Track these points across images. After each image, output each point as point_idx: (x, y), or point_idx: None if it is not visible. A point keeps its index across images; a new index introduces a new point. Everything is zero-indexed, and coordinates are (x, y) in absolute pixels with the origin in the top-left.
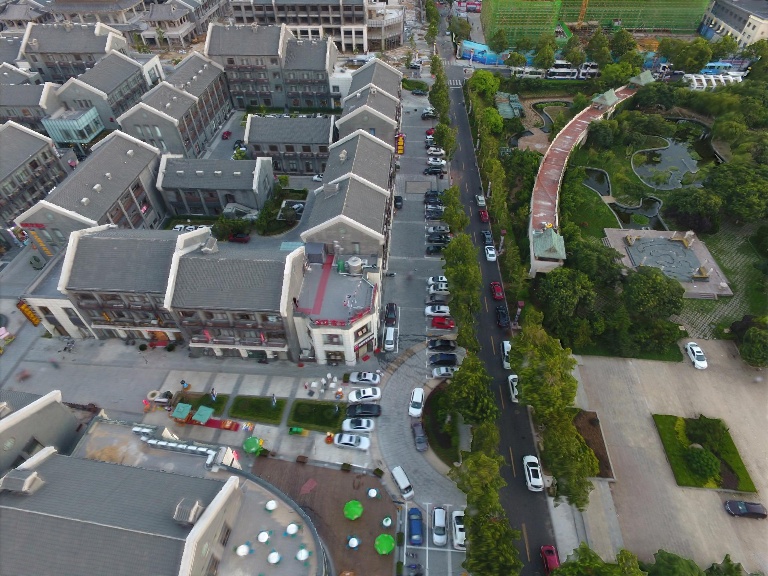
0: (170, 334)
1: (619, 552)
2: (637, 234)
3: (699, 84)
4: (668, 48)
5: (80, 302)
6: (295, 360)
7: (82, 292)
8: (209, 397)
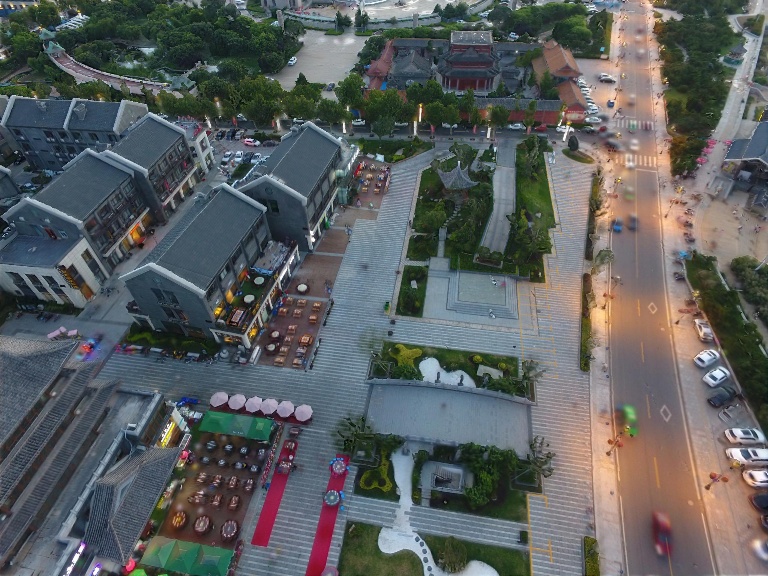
0: (141, 225)
1: None
2: None
3: (73, 27)
4: (20, 20)
5: (90, 234)
6: (199, 179)
7: (89, 220)
8: None
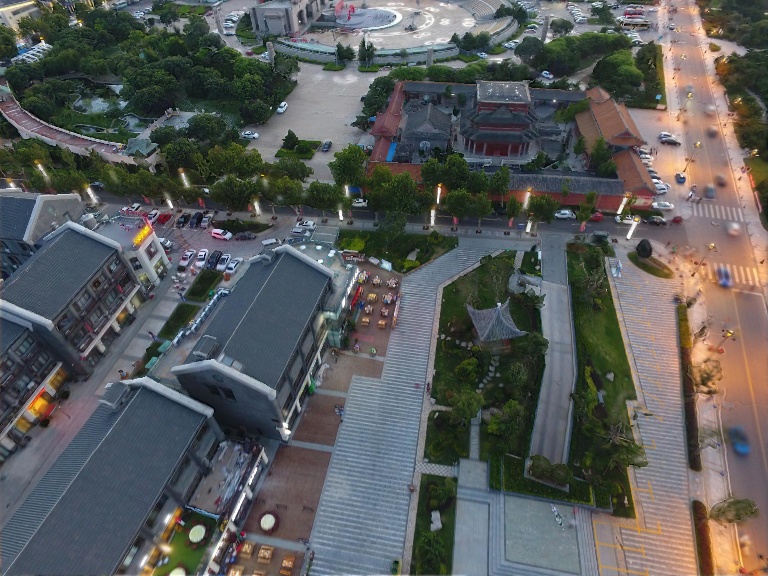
0: (49, 388)
1: (332, 182)
2: (152, 128)
3: (32, 59)
4: None
5: None
6: (145, 297)
7: None
8: None
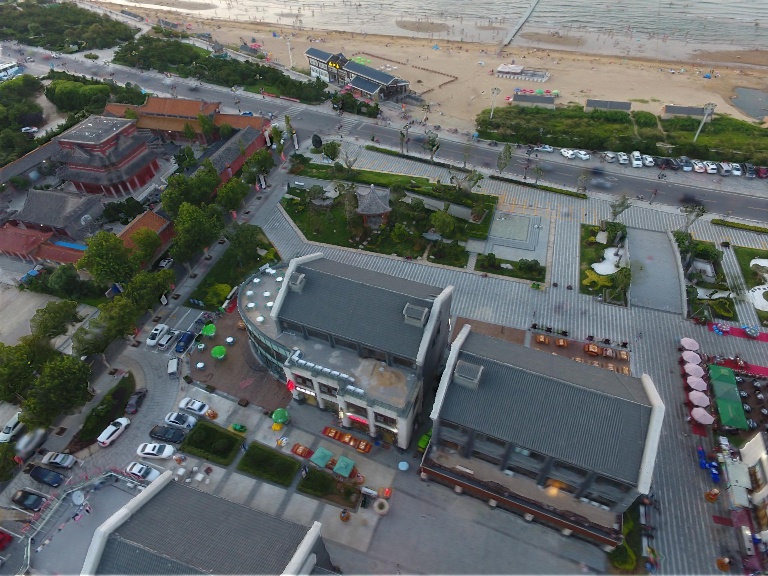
0: None
1: None
2: None
3: None
4: None
5: None
6: None
7: None
8: (314, 480)
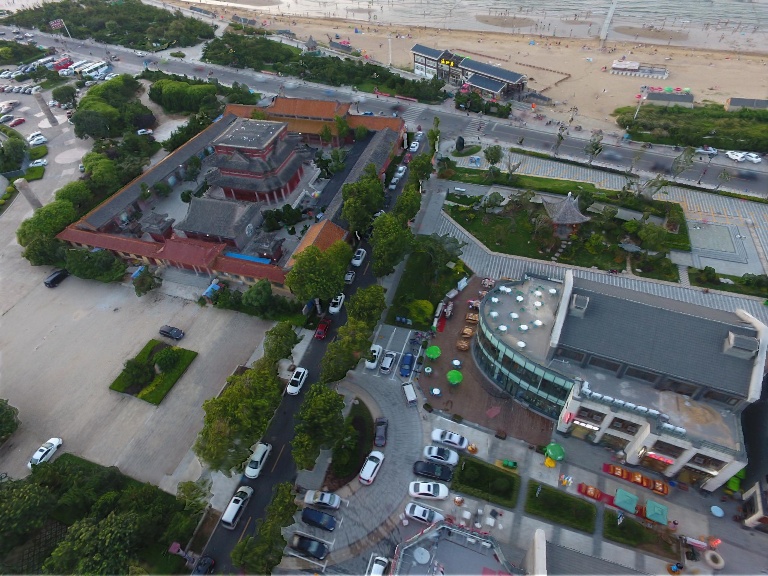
0: None
1: None
2: None
3: None
4: None
5: None
6: None
7: None
8: (629, 528)
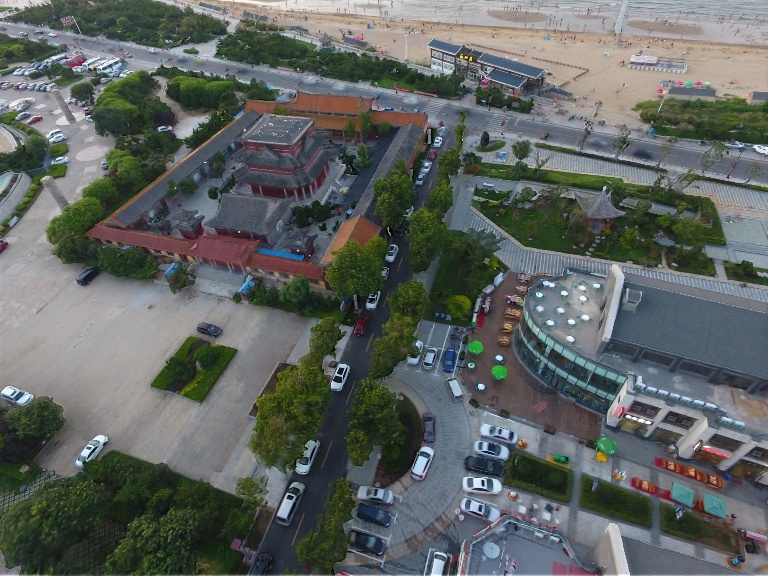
0: None
1: (313, 325)
2: None
3: None
4: None
5: None
6: None
7: None
8: (687, 522)
